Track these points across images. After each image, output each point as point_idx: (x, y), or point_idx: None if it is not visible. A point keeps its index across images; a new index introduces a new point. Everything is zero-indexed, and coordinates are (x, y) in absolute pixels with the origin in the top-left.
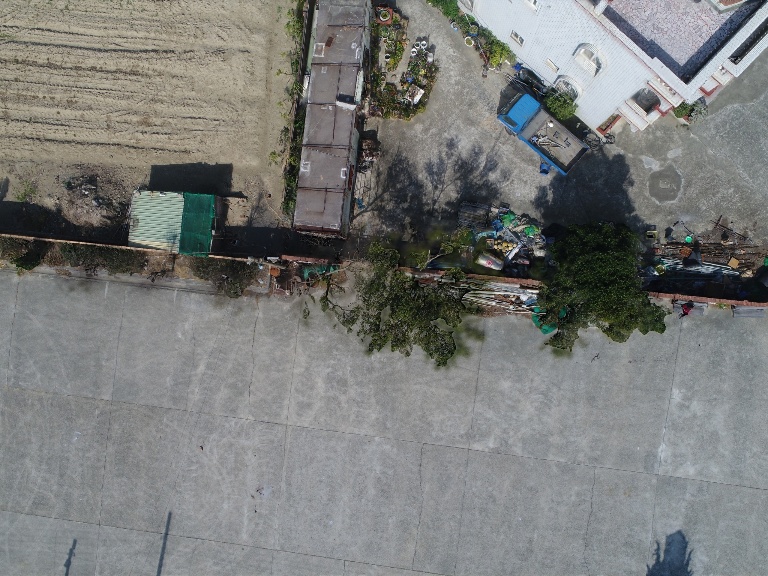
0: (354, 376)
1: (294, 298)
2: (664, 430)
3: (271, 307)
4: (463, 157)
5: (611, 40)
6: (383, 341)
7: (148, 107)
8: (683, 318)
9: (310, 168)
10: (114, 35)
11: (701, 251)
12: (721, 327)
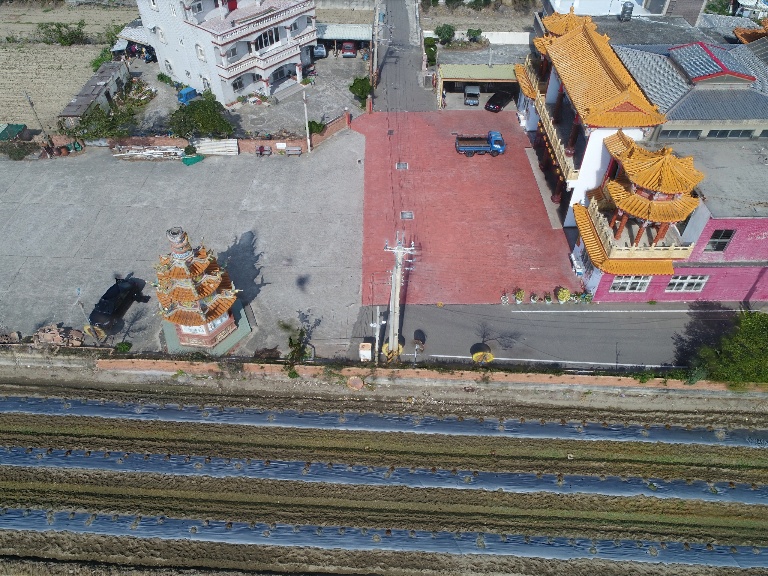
0: (73, 184)
1: (52, 160)
2: (247, 194)
3: (37, 163)
4: (161, 116)
5: (198, 32)
6: (85, 135)
7: (8, 114)
8: (262, 158)
9: (76, 101)
10: (4, 97)
11: (272, 137)
12: (282, 160)
